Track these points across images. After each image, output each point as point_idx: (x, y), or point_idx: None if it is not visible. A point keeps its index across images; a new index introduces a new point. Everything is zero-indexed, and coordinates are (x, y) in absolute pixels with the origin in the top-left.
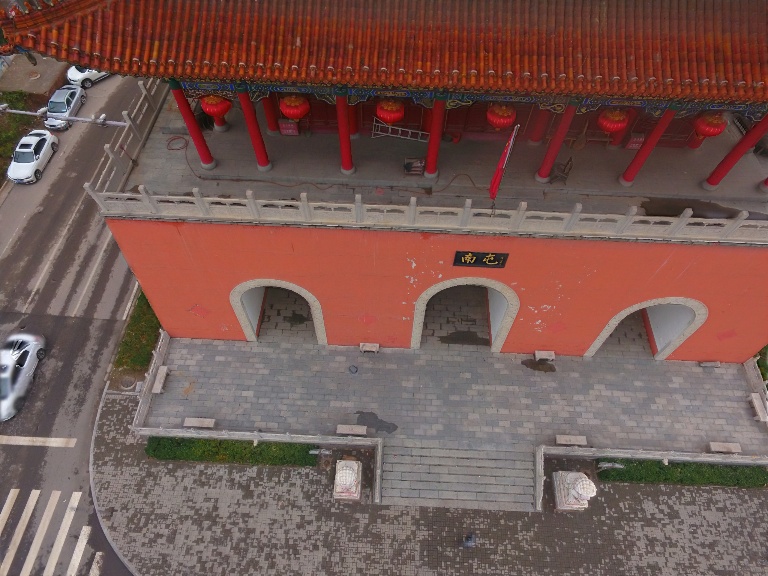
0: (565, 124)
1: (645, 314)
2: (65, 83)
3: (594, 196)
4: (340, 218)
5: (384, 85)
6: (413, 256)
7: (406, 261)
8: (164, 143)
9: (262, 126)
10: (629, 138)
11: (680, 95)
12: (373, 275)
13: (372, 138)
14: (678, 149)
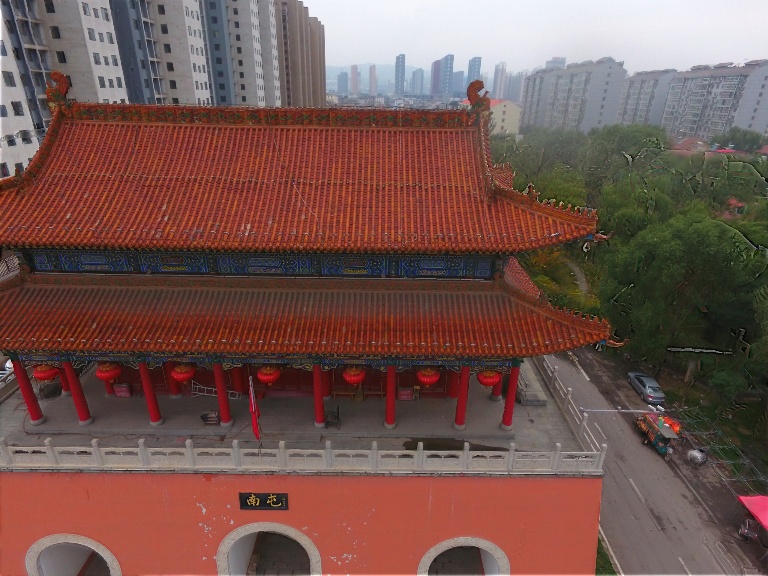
0: (316, 379)
1: (482, 571)
2: (1, 370)
3: (365, 438)
4: (129, 462)
5: (147, 351)
6: (201, 500)
7: (196, 506)
8: (14, 406)
9: (104, 391)
10: (397, 391)
11: (356, 353)
12: (168, 524)
13: (191, 397)
14: (442, 399)
